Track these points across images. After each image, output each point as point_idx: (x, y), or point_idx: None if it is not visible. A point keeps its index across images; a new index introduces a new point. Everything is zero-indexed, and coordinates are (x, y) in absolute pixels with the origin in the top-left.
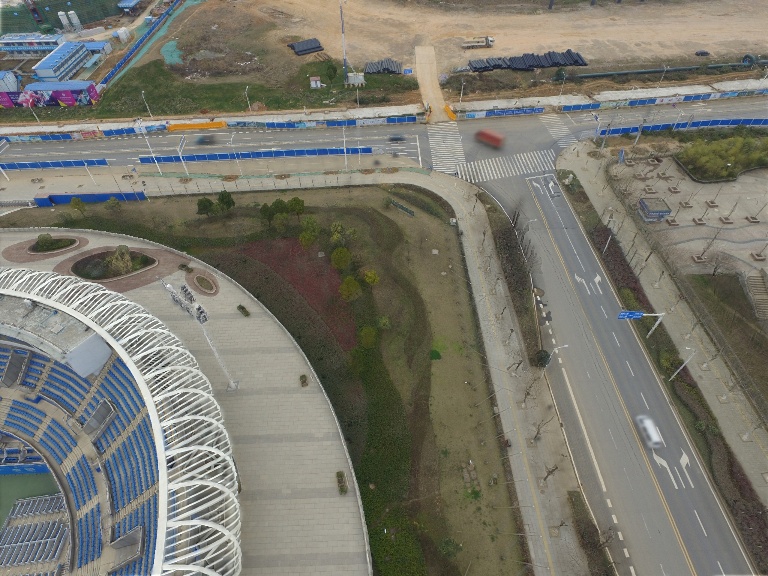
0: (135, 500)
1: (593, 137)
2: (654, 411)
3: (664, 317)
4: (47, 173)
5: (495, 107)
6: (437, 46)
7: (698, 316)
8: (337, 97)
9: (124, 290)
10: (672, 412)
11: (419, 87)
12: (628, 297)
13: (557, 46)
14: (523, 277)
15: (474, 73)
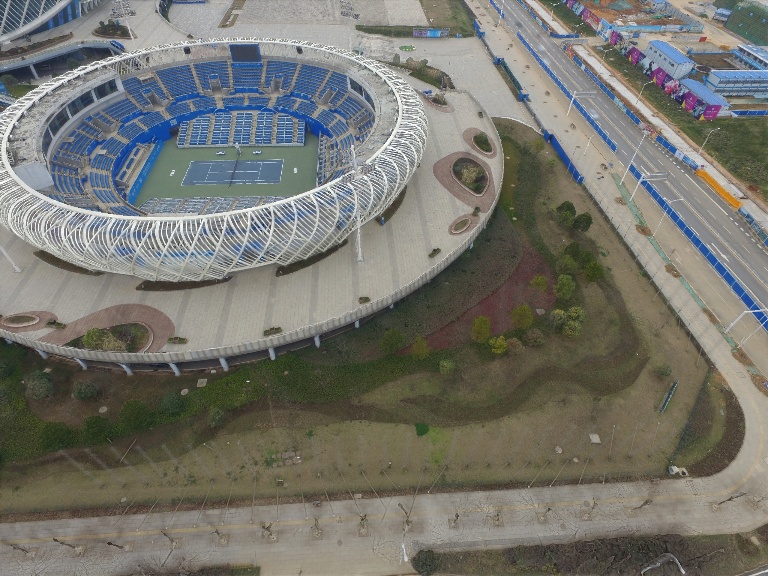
0: None
1: None
2: None
3: None
4: (586, 128)
5: None
6: None
7: None
8: None
9: (446, 187)
10: None
11: None
12: None
13: None
14: None
15: None
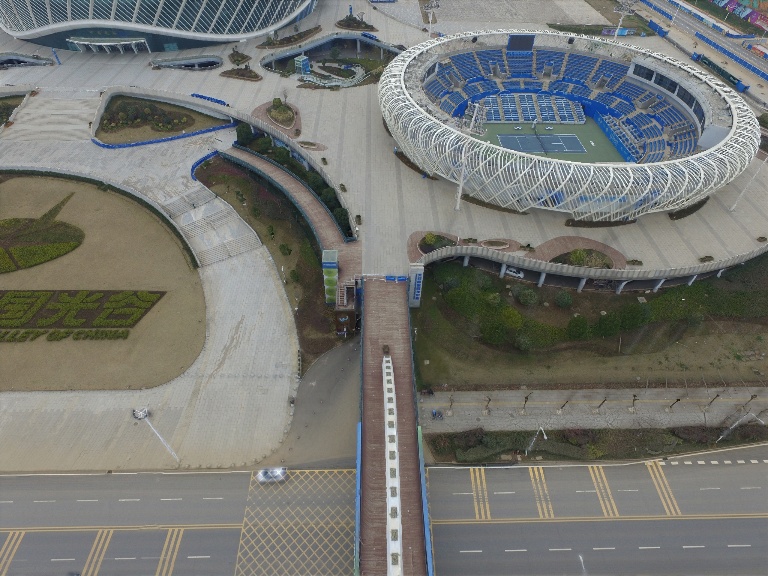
0: None
1: None
2: None
3: None
4: None
5: None
6: None
7: None
8: None
9: (758, 157)
10: None
11: None
12: None
13: None
14: None
15: None
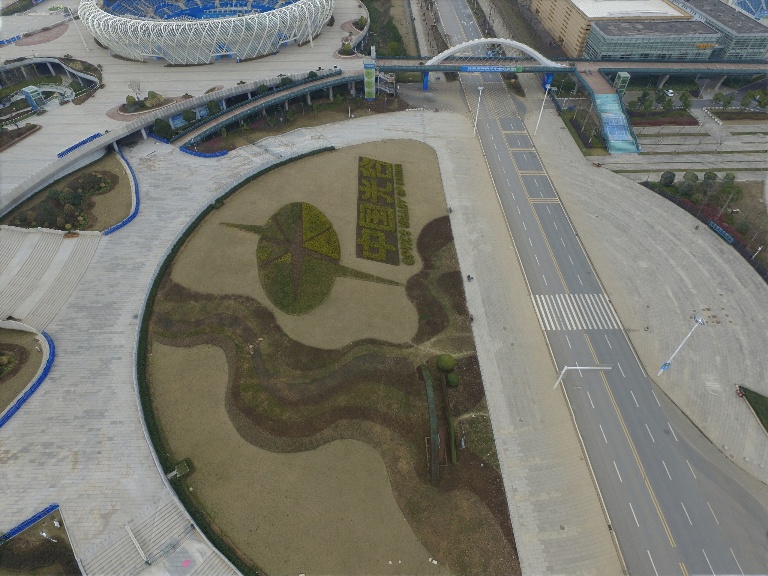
0: None
1: None
2: (466, 16)
3: (481, 3)
4: None
5: None
6: None
7: (493, 2)
8: None
9: None
10: (472, 16)
11: None
12: None
13: None
14: None
15: None
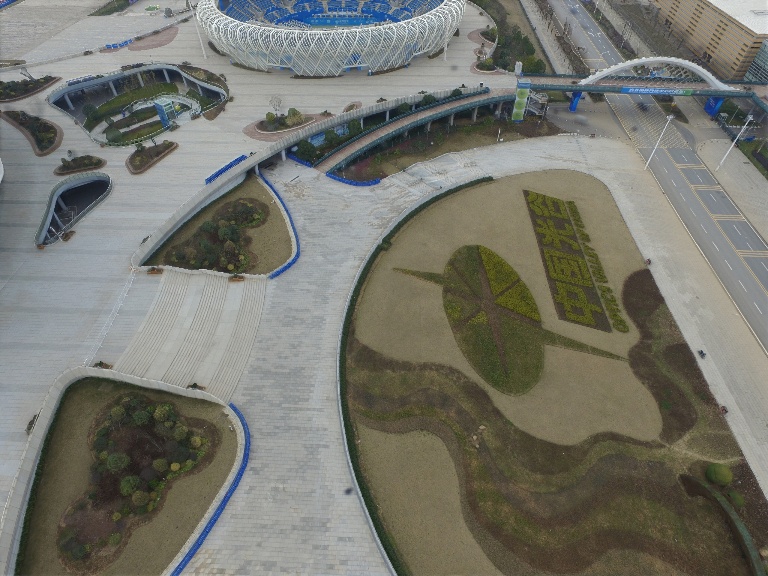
0: None
1: None
2: None
3: (603, 12)
4: None
5: None
6: None
7: None
8: None
9: None
10: (598, 27)
11: None
12: (589, 6)
13: None
14: None
15: None
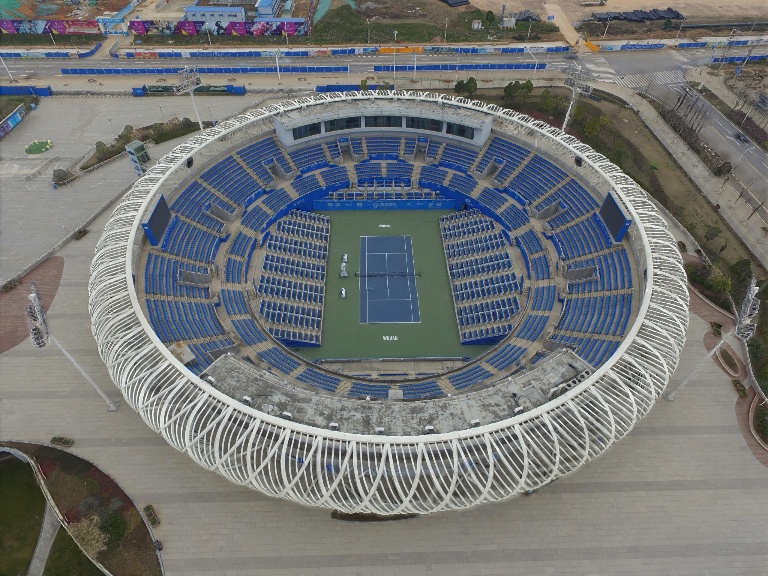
0: (543, 196)
1: (708, 63)
2: None
3: None
4: (305, 76)
5: (628, 42)
6: (560, 4)
7: None
8: (498, 35)
9: None
10: None
11: (560, 30)
12: (767, 145)
13: (657, 6)
14: (693, 134)
15: (599, 22)
